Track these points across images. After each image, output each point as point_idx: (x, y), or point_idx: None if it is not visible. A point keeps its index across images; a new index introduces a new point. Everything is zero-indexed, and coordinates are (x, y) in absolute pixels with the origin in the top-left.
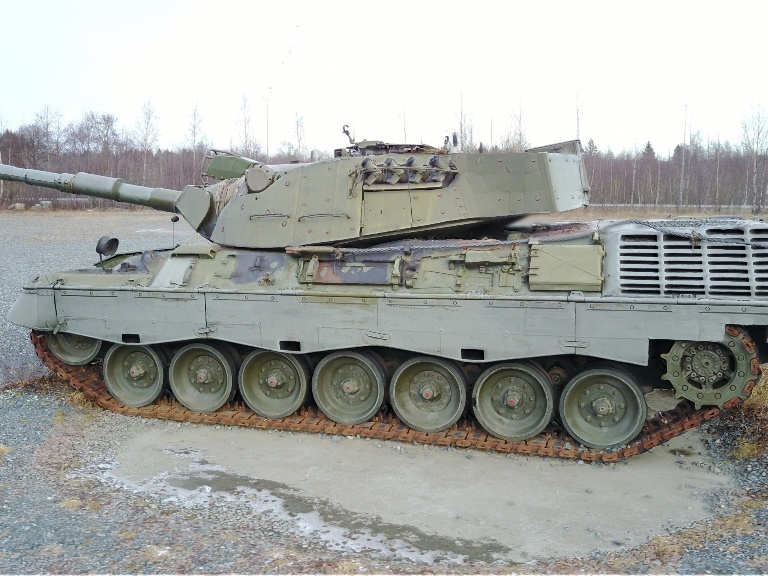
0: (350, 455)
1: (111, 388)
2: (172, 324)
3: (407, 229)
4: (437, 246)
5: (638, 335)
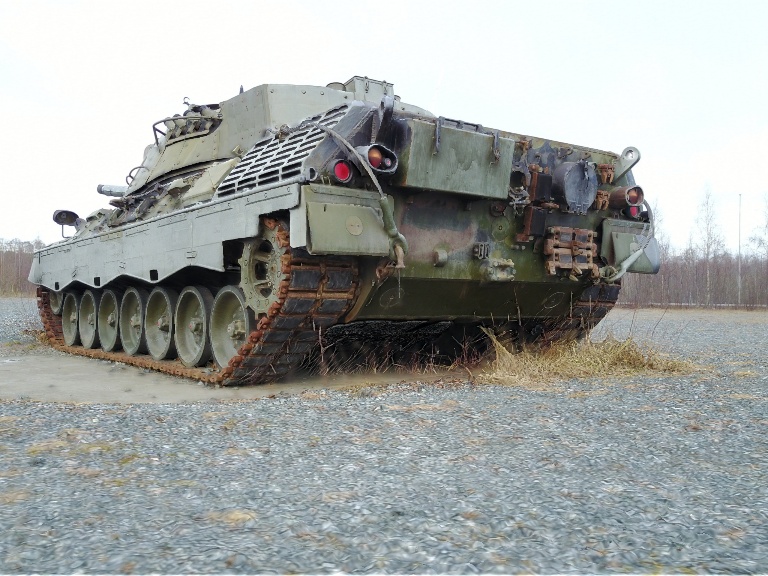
0: None
1: (64, 331)
2: (66, 271)
3: (171, 173)
4: (171, 182)
5: (218, 238)
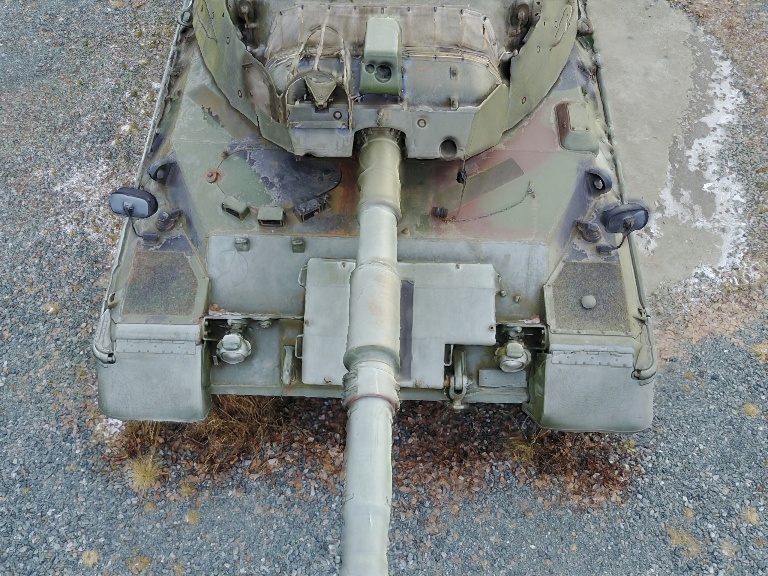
0: None
1: None
2: None
3: None
4: None
5: None
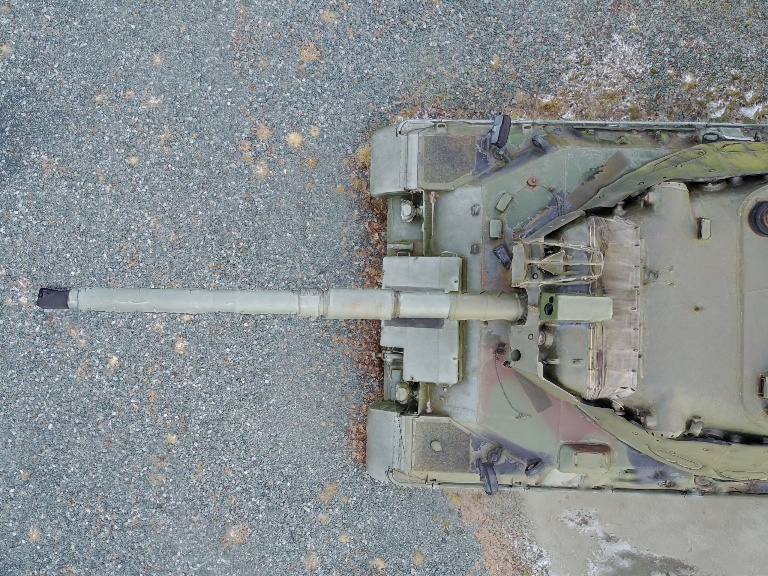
0: (707, 497)
1: None
2: None
3: None
4: None
5: None
